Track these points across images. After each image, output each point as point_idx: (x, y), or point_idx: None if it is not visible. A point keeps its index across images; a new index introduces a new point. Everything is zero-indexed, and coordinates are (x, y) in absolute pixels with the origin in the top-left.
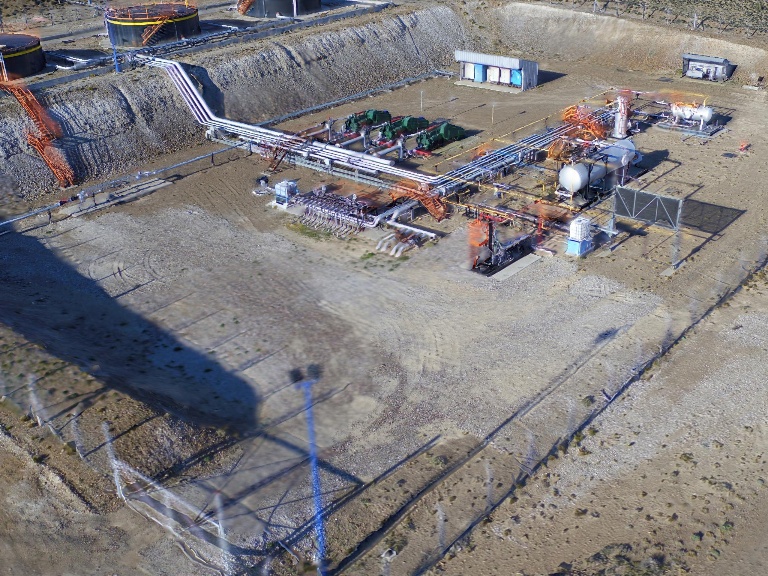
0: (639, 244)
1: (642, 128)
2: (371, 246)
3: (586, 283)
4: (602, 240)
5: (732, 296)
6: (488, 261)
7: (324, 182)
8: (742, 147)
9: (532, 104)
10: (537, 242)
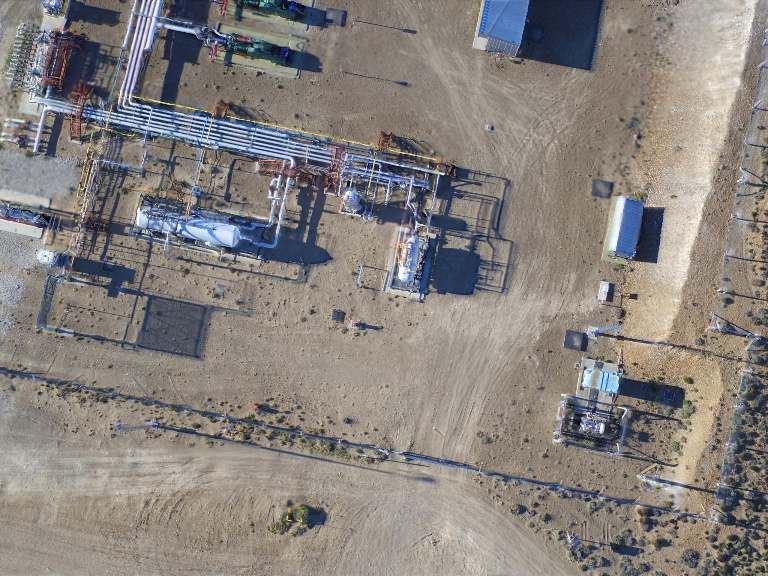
0: (91, 296)
1: (391, 217)
2: (8, 113)
3: (7, 281)
4: (87, 268)
5: (26, 377)
6: (12, 206)
7: (120, 4)
8: (354, 324)
9: (438, 79)
10: (65, 224)
